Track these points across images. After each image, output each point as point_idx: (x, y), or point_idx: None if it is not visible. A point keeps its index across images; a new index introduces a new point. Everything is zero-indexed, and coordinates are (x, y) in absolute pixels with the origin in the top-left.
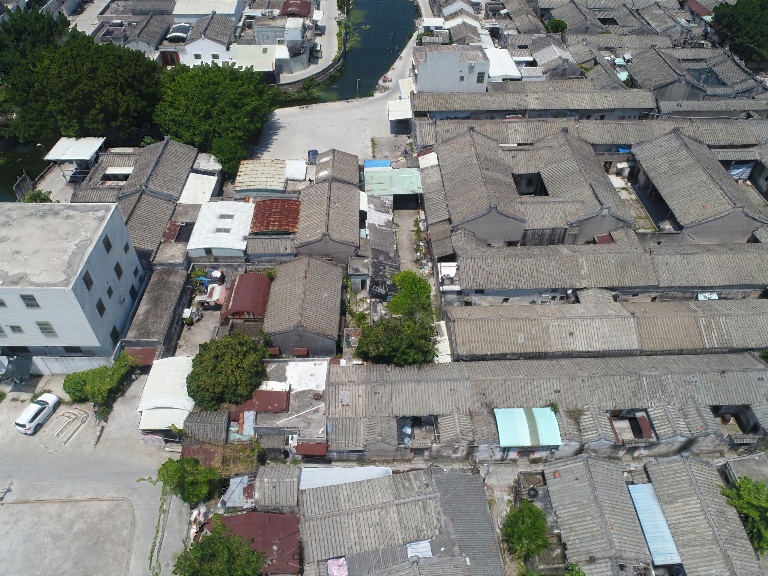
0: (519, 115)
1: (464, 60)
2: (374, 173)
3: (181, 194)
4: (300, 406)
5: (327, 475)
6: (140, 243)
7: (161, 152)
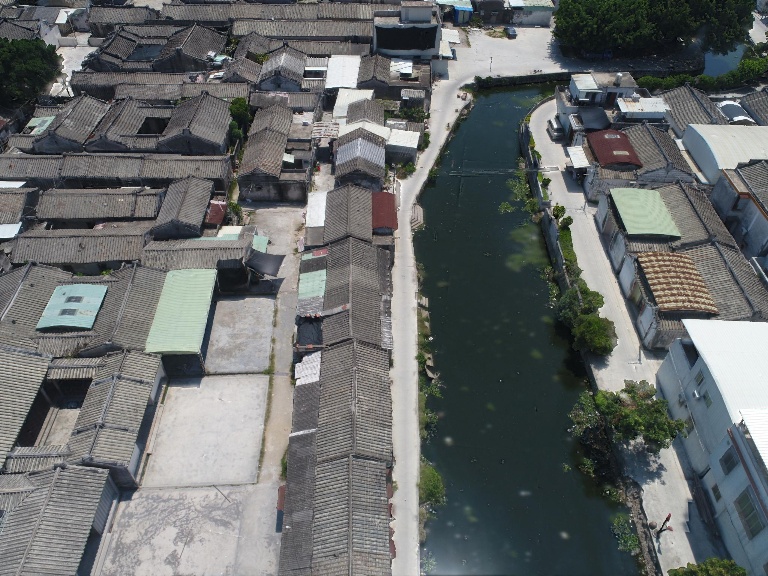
0: None
1: (394, 22)
2: (465, 5)
3: None
4: None
5: None
6: None
7: None
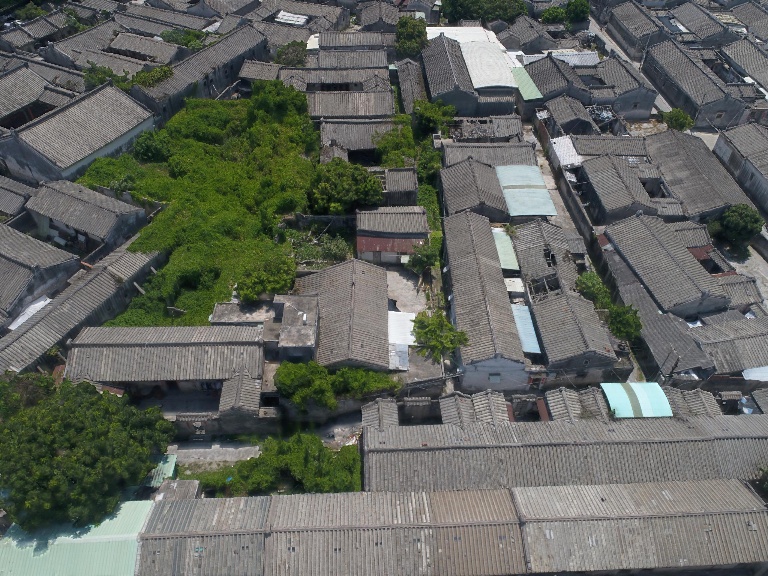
0: None
1: None
2: None
3: None
4: None
5: None
6: None
7: None
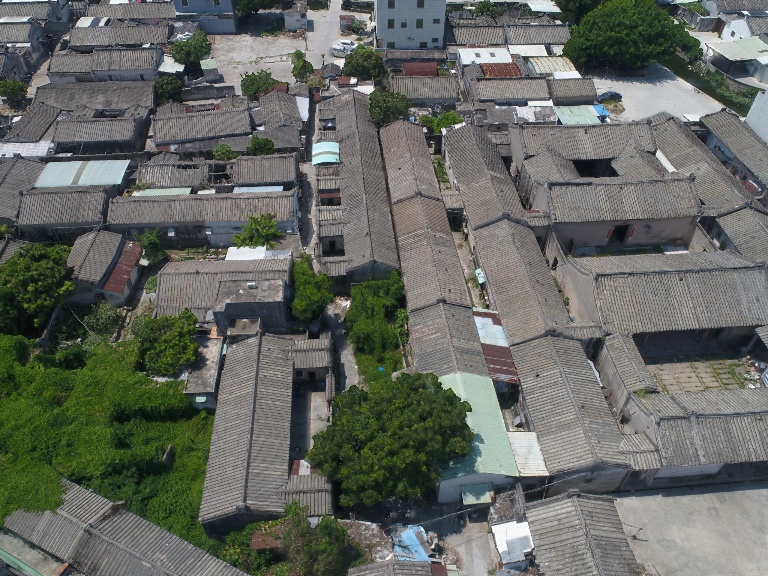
0: (760, 189)
1: None
2: (586, 109)
3: (518, 45)
4: (343, 90)
5: (304, 104)
6: (458, 36)
7: (549, 25)
